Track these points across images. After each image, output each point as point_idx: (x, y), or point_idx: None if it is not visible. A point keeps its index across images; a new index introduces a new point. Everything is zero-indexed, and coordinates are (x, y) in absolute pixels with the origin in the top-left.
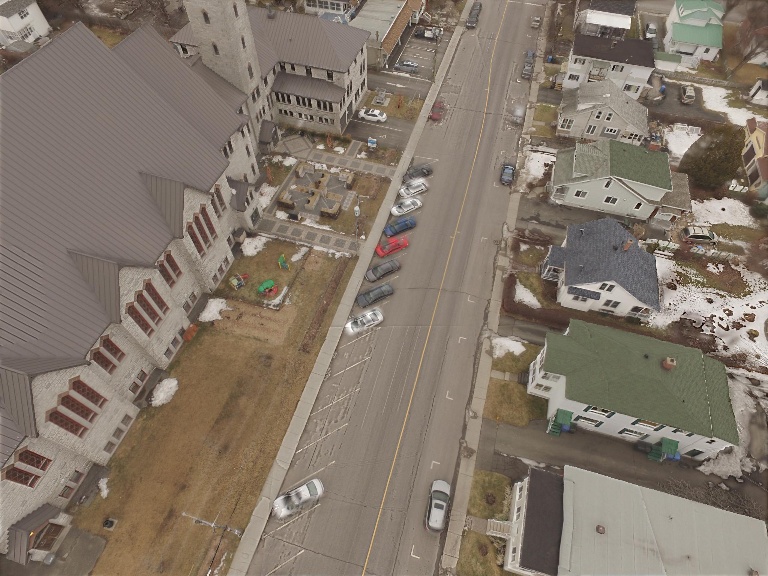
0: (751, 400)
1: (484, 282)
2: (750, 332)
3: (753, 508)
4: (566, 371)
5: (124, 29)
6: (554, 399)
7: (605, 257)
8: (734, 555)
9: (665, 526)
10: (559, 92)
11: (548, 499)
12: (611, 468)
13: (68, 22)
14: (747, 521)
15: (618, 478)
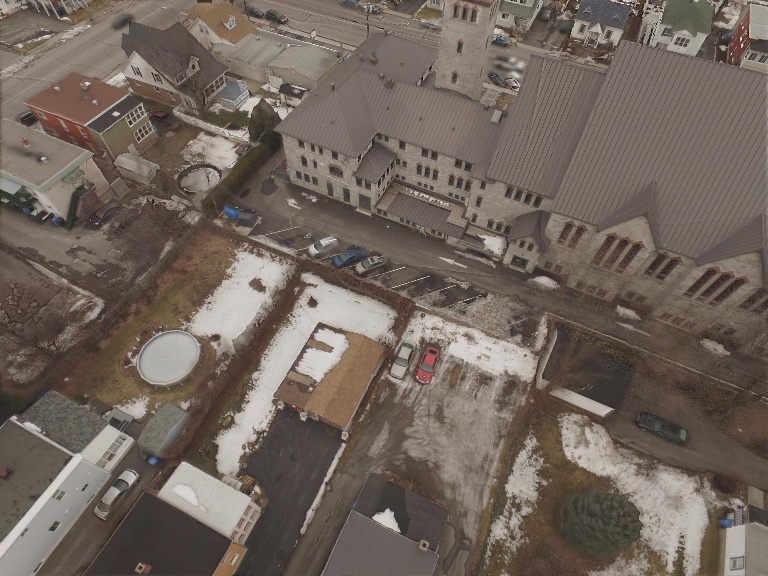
0: (659, 12)
1: (599, 70)
2: (620, 1)
3: (712, 27)
4: (695, 30)
5: (137, 299)
6: (690, 53)
7: (613, 6)
8: (767, 12)
9: (764, 22)
10: (401, 4)
11: (766, 46)
12: (708, 55)
13: (61, 389)
14: (753, 6)
15: (712, 54)
